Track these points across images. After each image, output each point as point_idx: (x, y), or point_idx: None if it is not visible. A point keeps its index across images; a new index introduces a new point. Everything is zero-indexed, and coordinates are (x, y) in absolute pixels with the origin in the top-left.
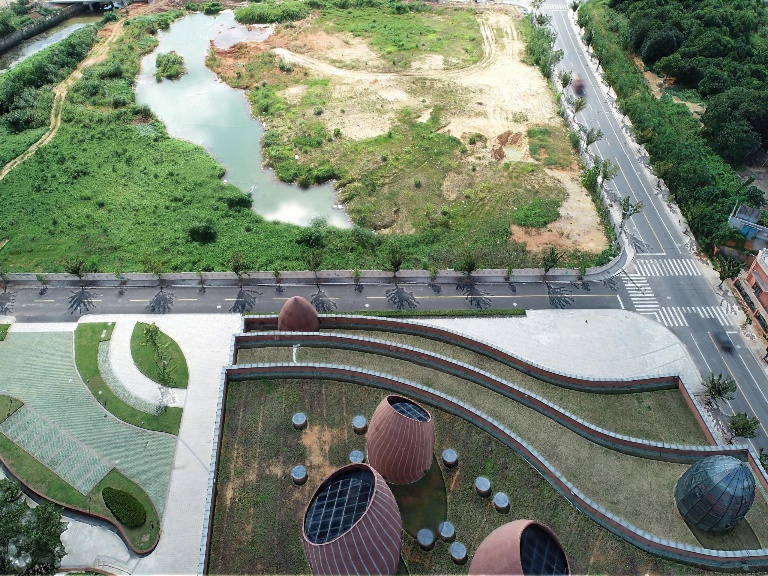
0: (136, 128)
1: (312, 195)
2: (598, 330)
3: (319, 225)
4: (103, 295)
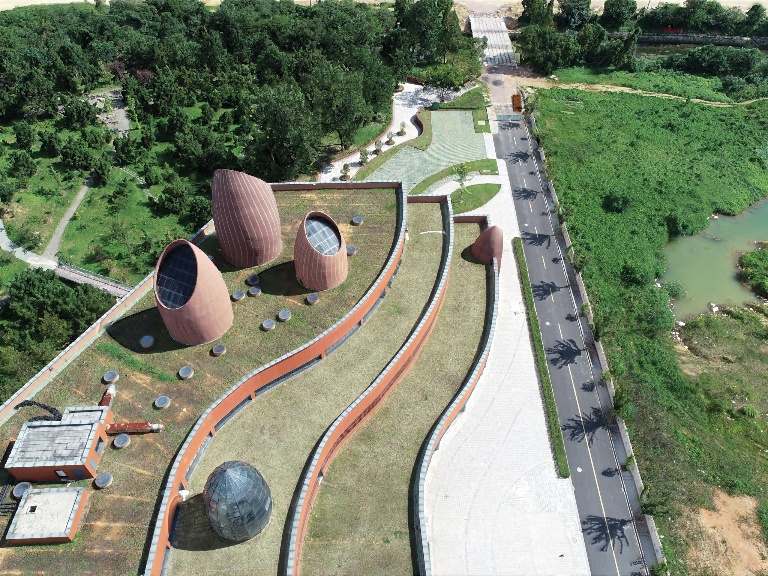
0: (766, 146)
1: (726, 285)
2: (548, 568)
3: (669, 289)
4: (527, 165)
